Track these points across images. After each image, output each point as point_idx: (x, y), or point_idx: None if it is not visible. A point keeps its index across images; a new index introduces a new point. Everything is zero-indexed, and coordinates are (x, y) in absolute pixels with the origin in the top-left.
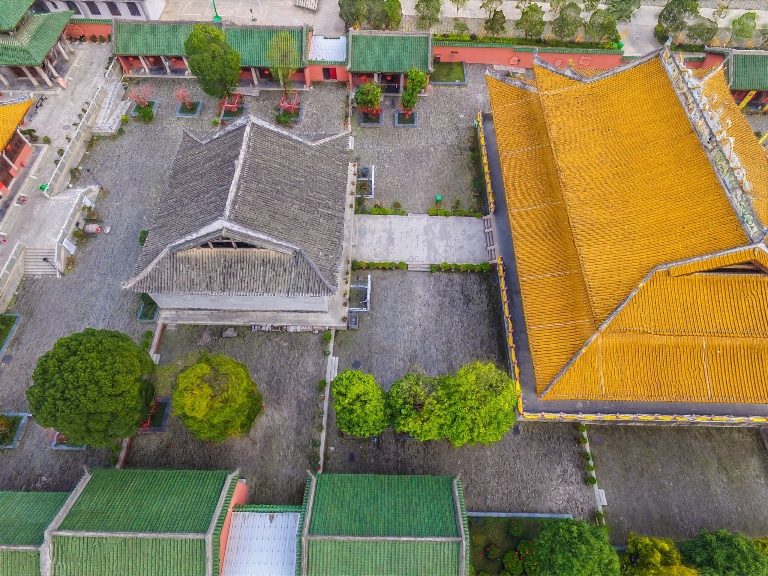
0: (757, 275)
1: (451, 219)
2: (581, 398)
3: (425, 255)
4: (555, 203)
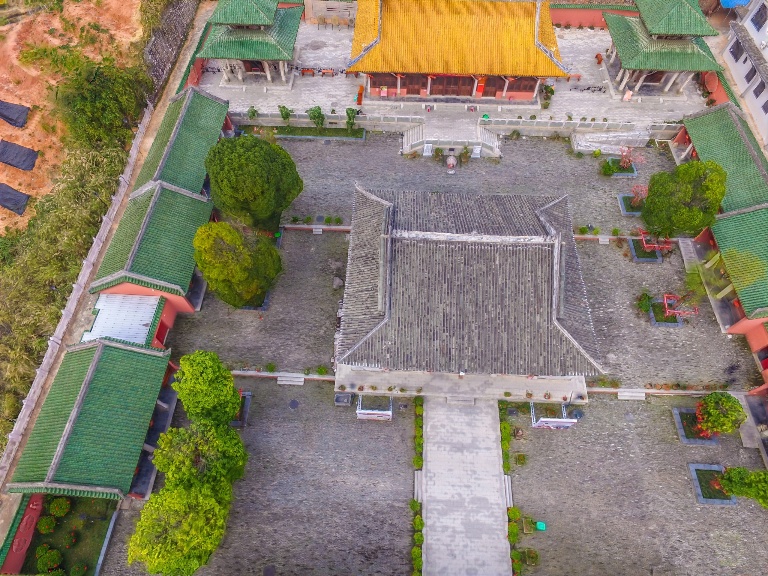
0: None
1: (504, 544)
2: None
3: (437, 495)
4: None
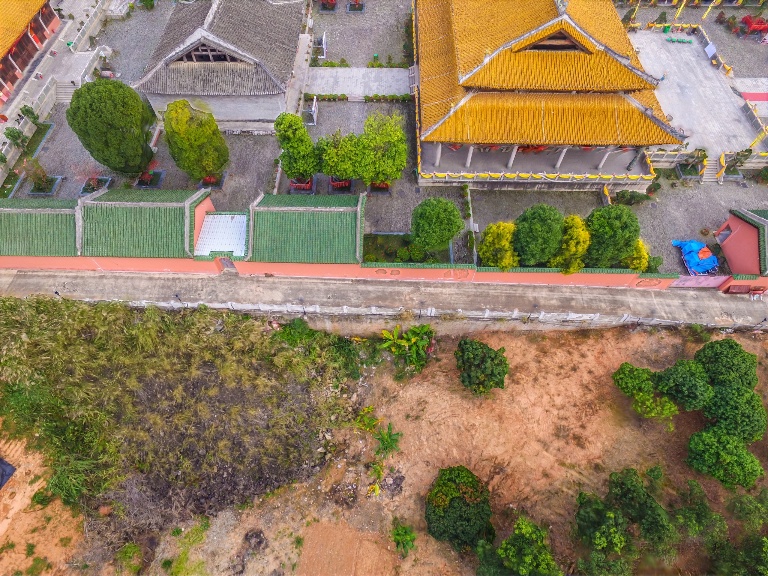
0: (575, 51)
1: (384, 69)
2: (452, 141)
3: (361, 91)
4: (451, 34)
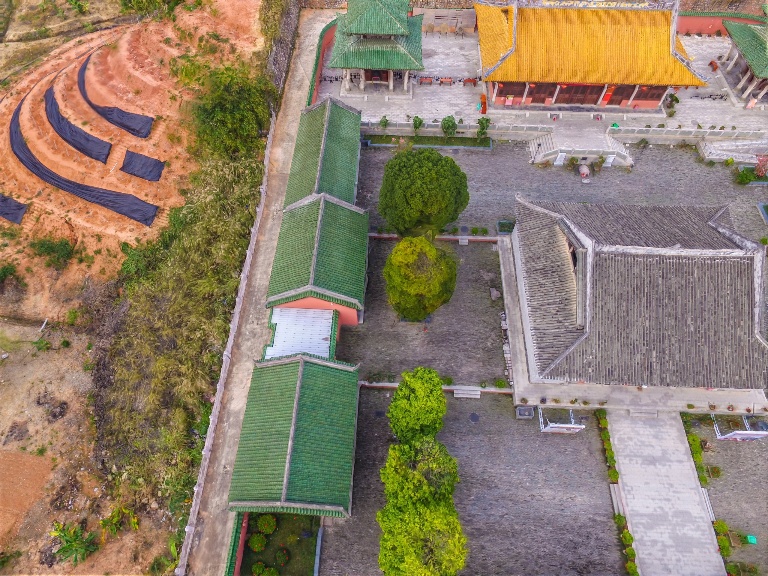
0: None
1: (717, 558)
2: None
3: (639, 509)
4: None
